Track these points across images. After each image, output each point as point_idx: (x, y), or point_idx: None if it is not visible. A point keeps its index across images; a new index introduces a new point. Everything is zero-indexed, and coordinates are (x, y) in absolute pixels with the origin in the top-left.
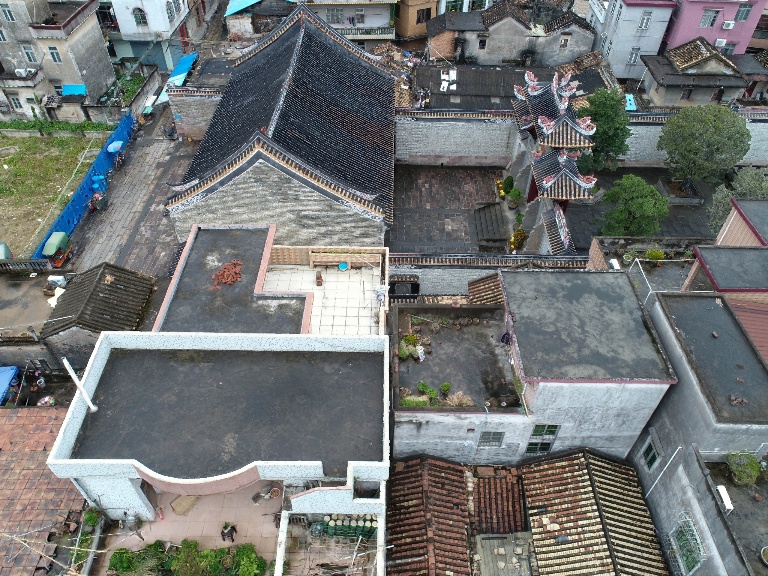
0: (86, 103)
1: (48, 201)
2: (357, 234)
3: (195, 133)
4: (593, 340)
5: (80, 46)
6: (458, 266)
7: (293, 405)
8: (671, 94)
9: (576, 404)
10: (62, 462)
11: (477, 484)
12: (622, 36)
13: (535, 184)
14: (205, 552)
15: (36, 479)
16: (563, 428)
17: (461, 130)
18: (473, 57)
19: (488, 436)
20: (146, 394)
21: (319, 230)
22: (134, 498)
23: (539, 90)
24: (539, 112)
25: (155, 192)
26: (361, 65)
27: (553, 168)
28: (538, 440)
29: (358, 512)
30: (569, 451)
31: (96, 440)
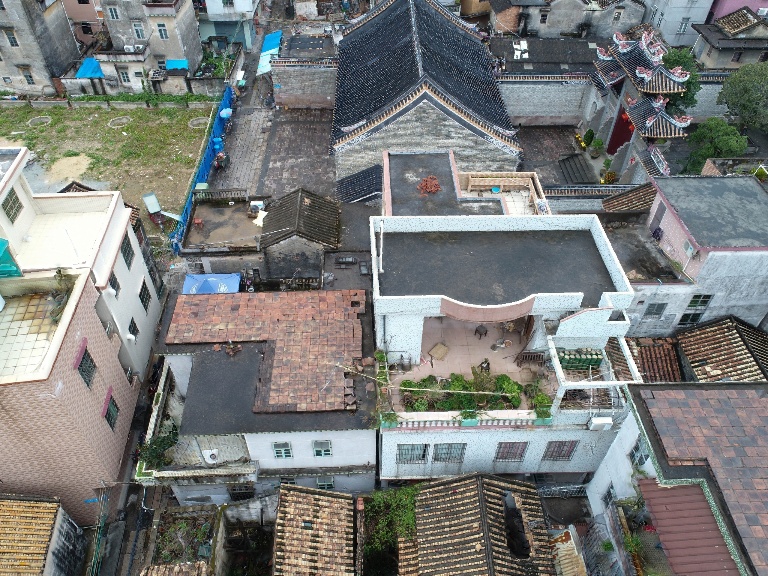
0: (188, 76)
1: (173, 162)
2: (493, 168)
3: (291, 102)
4: (743, 222)
5: (182, 24)
6: (574, 196)
7: (535, 265)
8: (723, 57)
9: (732, 273)
10: (388, 298)
11: (640, 351)
12: (674, 7)
13: (616, 135)
14: (471, 381)
15: (317, 338)
16: (715, 298)
17: (540, 92)
18: (534, 31)
19: (653, 308)
20: (417, 261)
21: (461, 165)
22: (417, 339)
23: (628, 48)
24: (632, 66)
25: (269, 152)
26: (458, 32)
27: (649, 112)
28: (692, 311)
29: (606, 335)
30: (718, 318)
31: (394, 290)
